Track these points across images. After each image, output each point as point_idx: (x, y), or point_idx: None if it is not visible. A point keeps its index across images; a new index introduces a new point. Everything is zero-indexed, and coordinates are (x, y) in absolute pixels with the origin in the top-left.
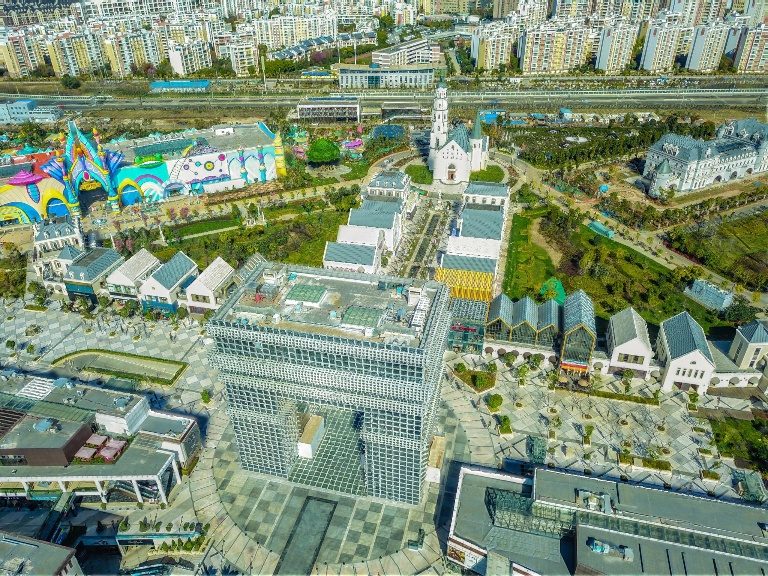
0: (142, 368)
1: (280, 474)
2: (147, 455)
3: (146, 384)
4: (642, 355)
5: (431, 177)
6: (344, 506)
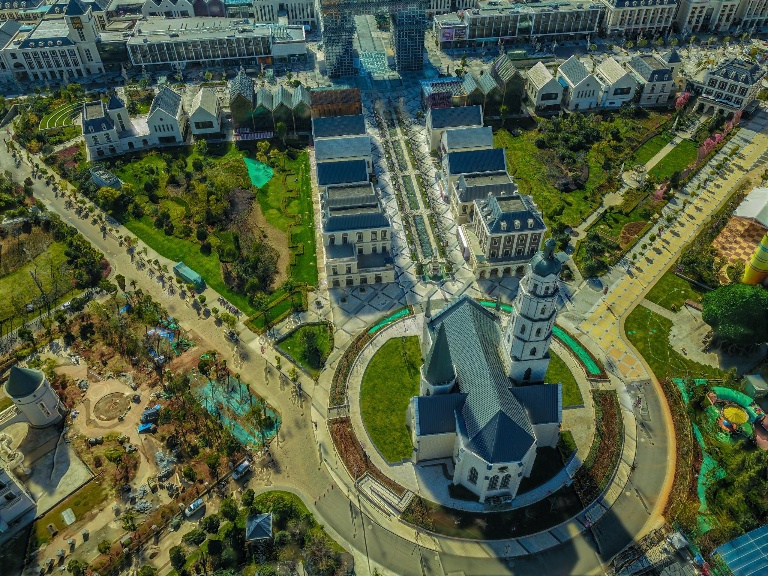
0: None
1: None
2: None
3: None
4: None
5: None
6: None
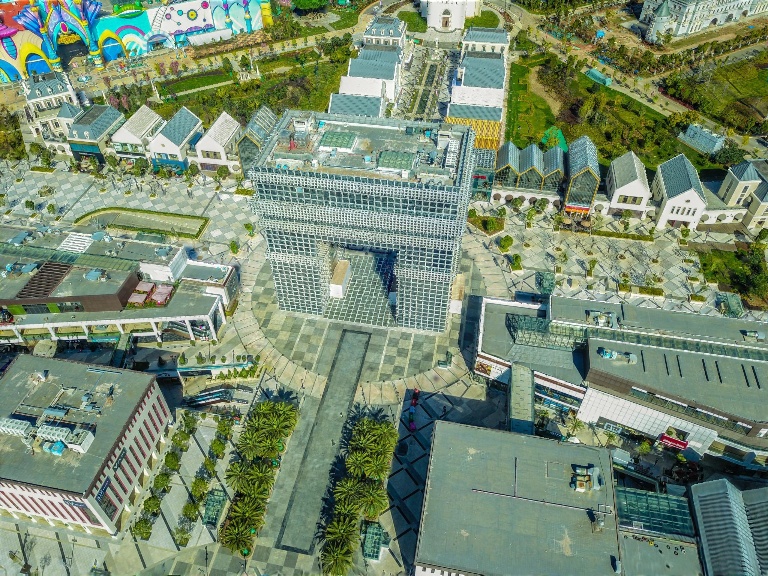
0: (164, 224)
1: (316, 312)
2: (195, 298)
3: (173, 238)
4: (641, 196)
5: (424, 24)
6: (377, 336)
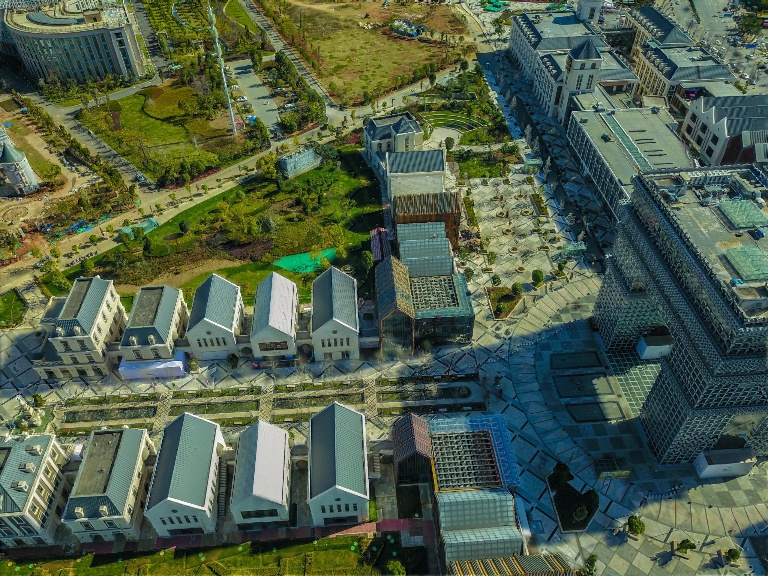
0: None
1: None
2: None
3: None
4: None
5: None
6: None
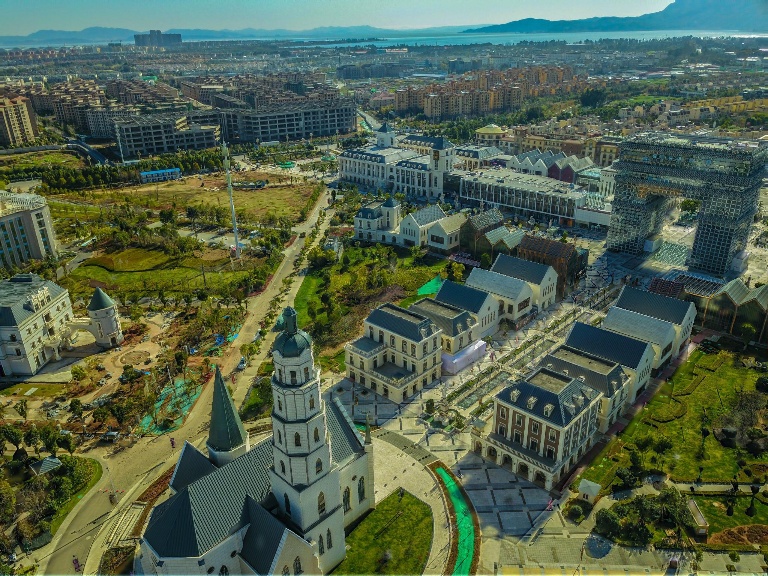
0: None
1: None
2: None
3: None
4: None
5: (374, 517)
6: None
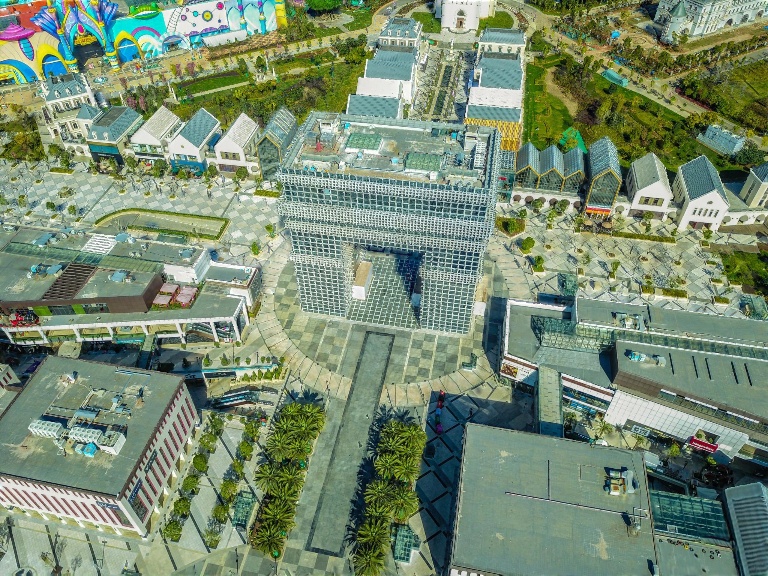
0: (184, 225)
1: (338, 314)
2: (219, 300)
3: (193, 240)
4: (662, 197)
5: (439, 25)
6: (401, 338)
